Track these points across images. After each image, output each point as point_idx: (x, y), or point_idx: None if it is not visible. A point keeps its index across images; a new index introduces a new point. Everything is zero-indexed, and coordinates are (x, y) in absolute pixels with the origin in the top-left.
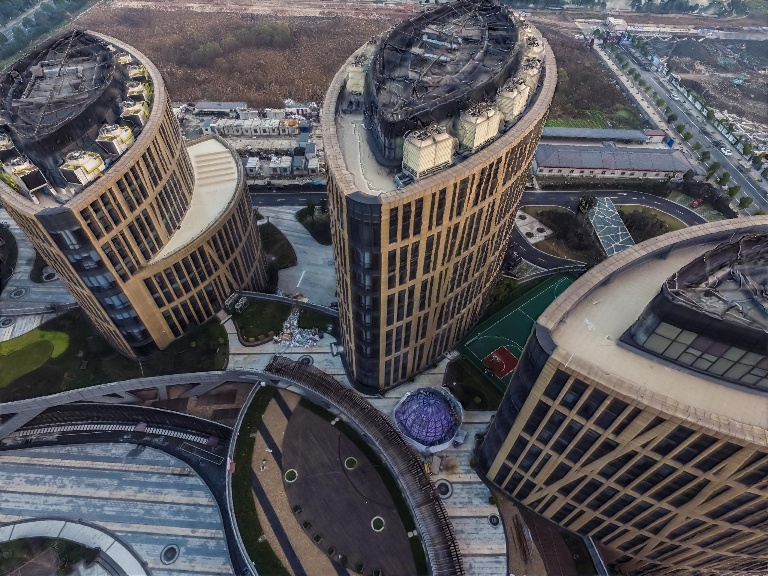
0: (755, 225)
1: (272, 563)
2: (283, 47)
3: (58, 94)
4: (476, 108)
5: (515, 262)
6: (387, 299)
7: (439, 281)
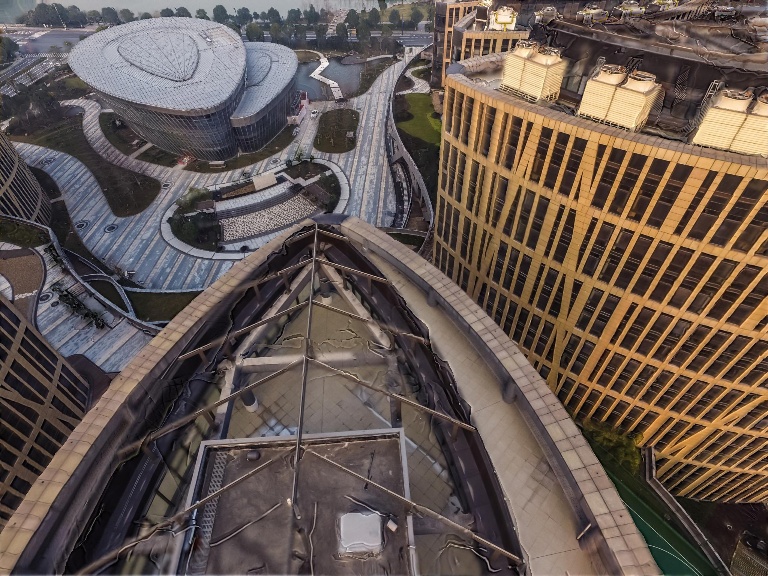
0: (626, 575)
1: None
2: None
3: None
4: (624, 67)
5: (766, 551)
6: (440, 199)
7: (482, 241)
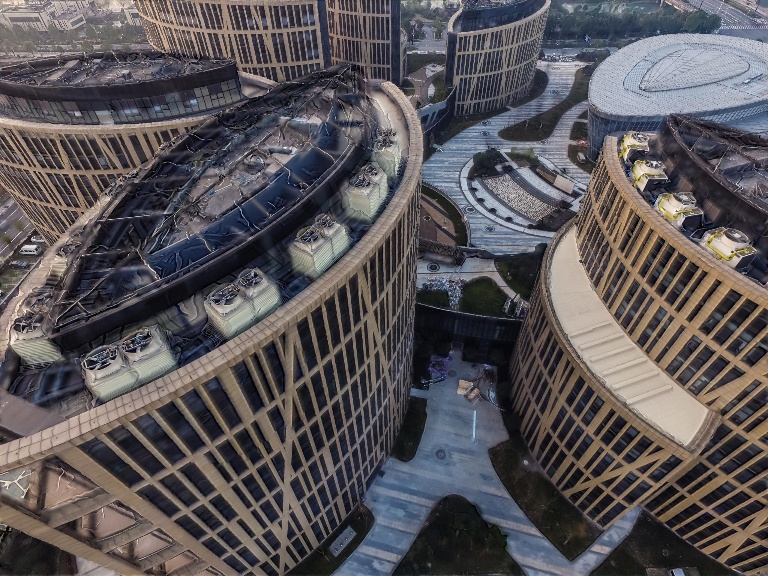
0: None
1: (428, 192)
2: None
3: (749, 163)
4: None
5: None
6: None
7: None
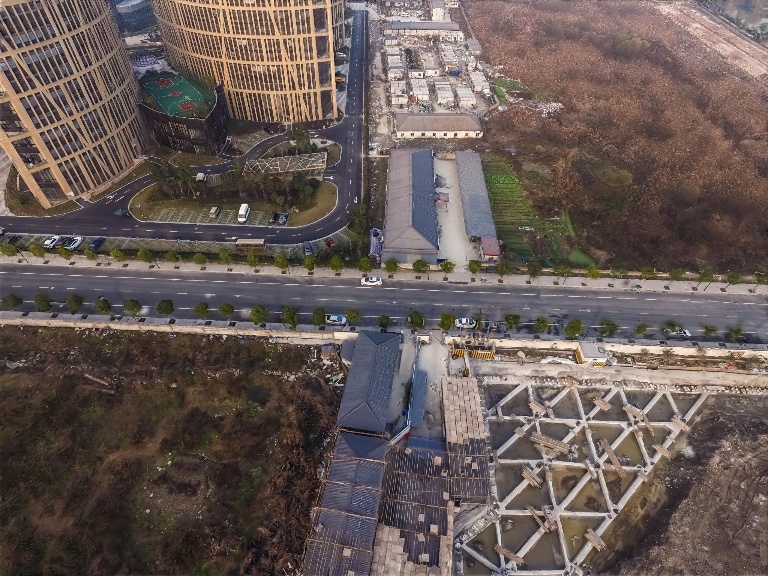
0: None
1: None
2: (605, 54)
3: None
4: None
5: None
6: None
7: None
